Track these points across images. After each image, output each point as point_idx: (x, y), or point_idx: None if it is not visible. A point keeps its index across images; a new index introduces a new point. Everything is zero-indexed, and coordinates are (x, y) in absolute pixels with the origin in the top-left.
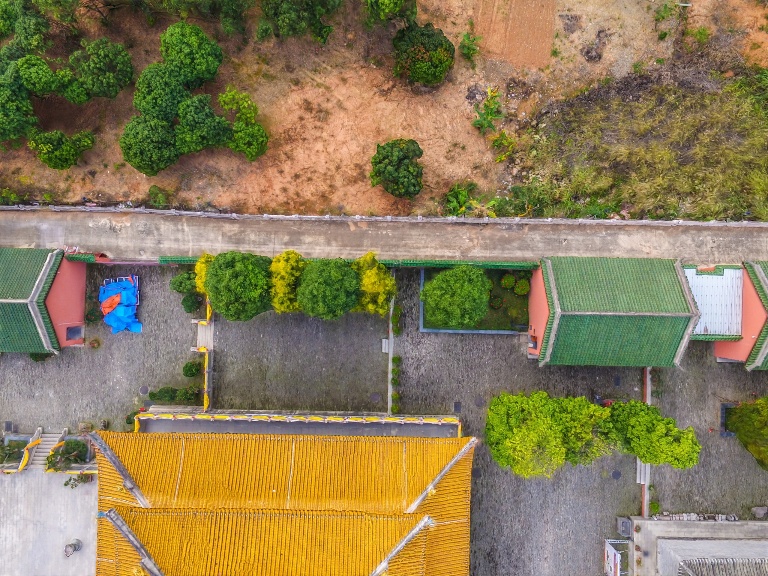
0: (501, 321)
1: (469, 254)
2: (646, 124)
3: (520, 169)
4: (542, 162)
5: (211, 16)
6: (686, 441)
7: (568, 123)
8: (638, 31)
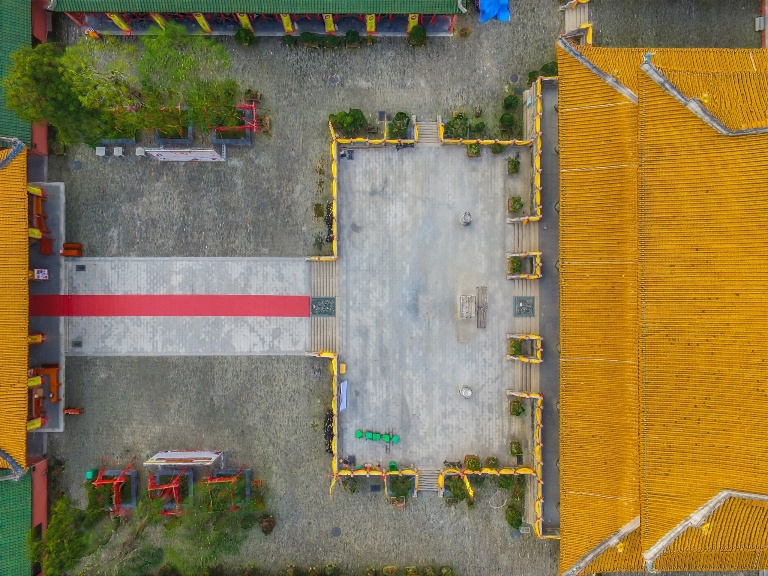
0: None
1: None
2: None
3: None
4: None
5: None
6: None
7: None
8: None
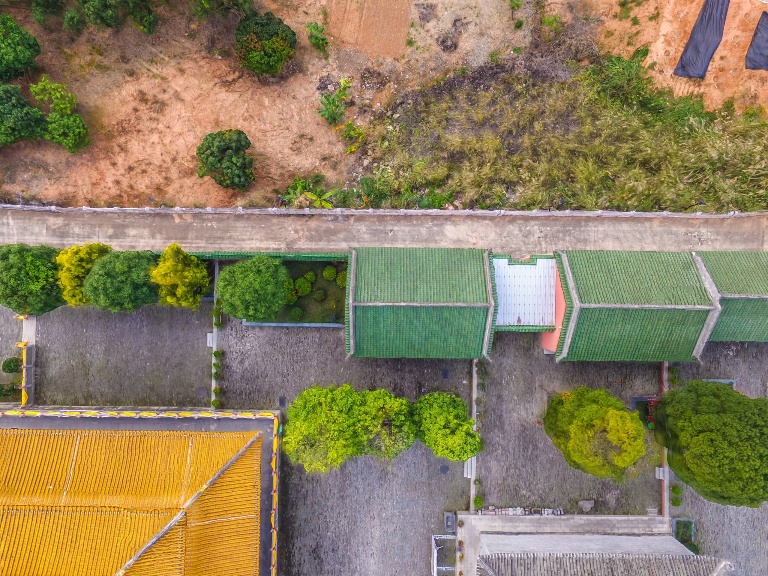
0: (326, 314)
1: (294, 246)
2: (487, 113)
3: (371, 160)
4: (392, 153)
5: (24, 5)
6: (459, 433)
7: (419, 113)
8: (495, 20)
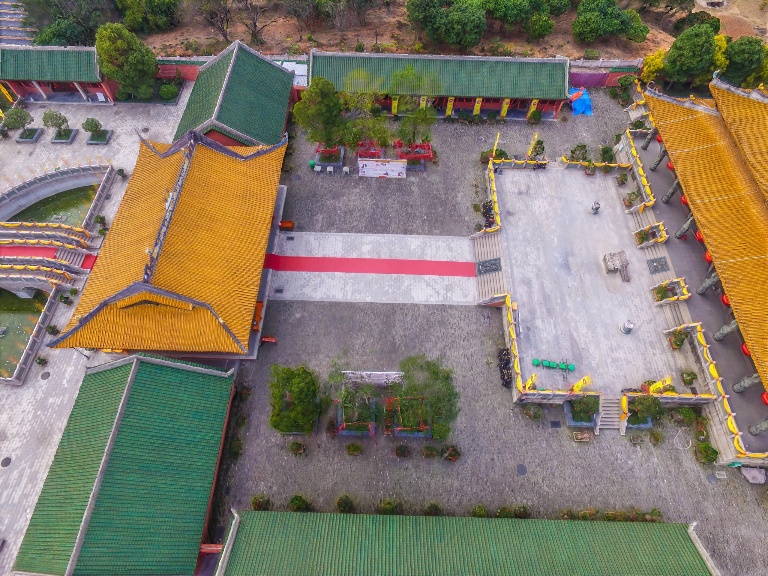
0: None
1: None
2: None
3: None
4: None
5: None
6: None
7: None
8: None
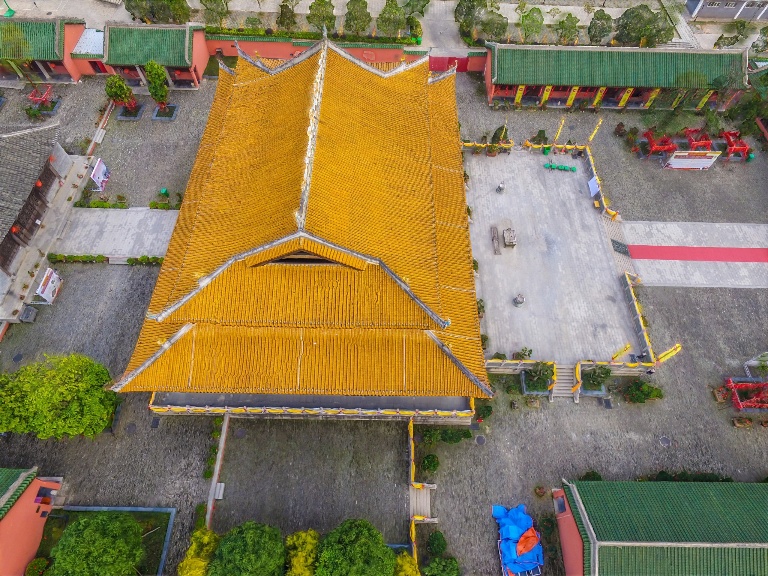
0: None
1: None
2: None
3: None
4: None
5: None
6: None
7: None
8: None
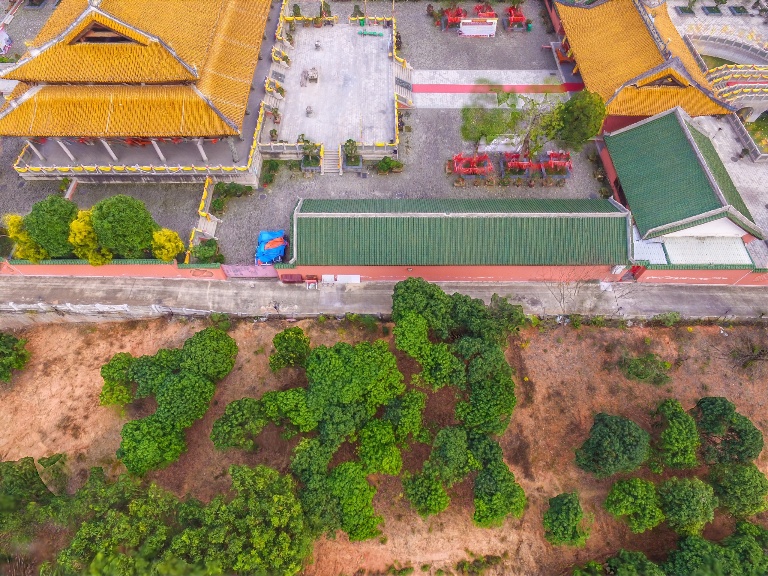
0: None
1: None
2: None
3: None
4: None
5: None
6: None
7: None
8: None
